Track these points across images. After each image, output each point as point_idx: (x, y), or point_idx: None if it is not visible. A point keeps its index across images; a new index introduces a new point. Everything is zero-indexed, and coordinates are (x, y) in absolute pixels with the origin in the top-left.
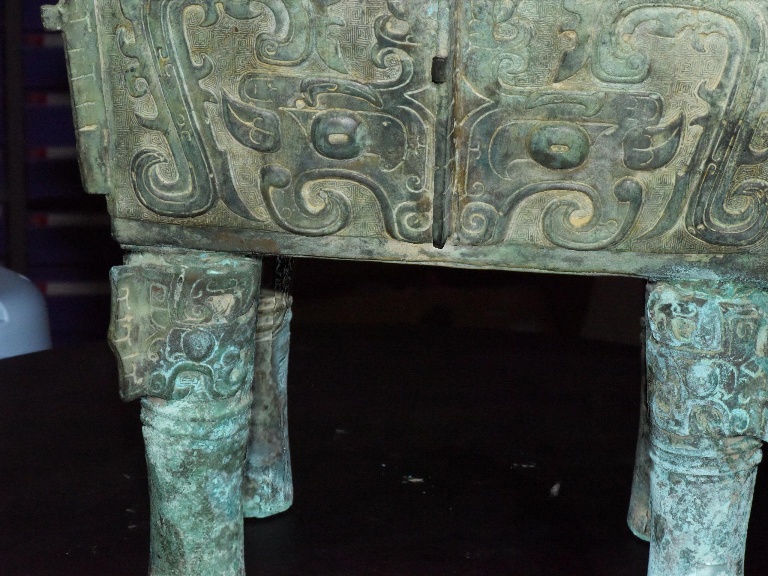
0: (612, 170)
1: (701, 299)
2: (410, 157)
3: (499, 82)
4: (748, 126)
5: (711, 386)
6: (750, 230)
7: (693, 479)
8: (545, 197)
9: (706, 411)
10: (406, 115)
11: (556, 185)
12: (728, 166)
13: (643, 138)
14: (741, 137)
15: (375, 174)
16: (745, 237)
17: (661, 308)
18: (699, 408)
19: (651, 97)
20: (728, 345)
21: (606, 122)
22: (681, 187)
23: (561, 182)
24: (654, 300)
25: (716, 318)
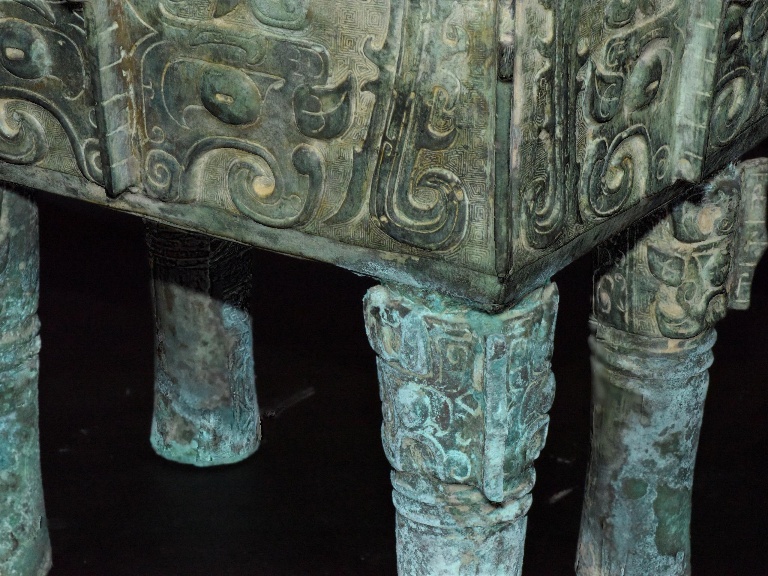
0: (287, 133)
1: (405, 308)
2: (89, 86)
3: (161, 9)
4: (422, 101)
5: (417, 417)
6: (439, 232)
7: (414, 525)
8: (227, 155)
9: (421, 446)
10: (78, 35)
11: (230, 142)
12: (407, 148)
13: (311, 99)
14: (416, 113)
15: (59, 101)
16: (434, 240)
17: (372, 310)
18: (412, 441)
19: (315, 49)
20: (437, 370)
21: (272, 73)
22: (359, 166)
23: (236, 140)
24: (366, 299)
25: (417, 334)
